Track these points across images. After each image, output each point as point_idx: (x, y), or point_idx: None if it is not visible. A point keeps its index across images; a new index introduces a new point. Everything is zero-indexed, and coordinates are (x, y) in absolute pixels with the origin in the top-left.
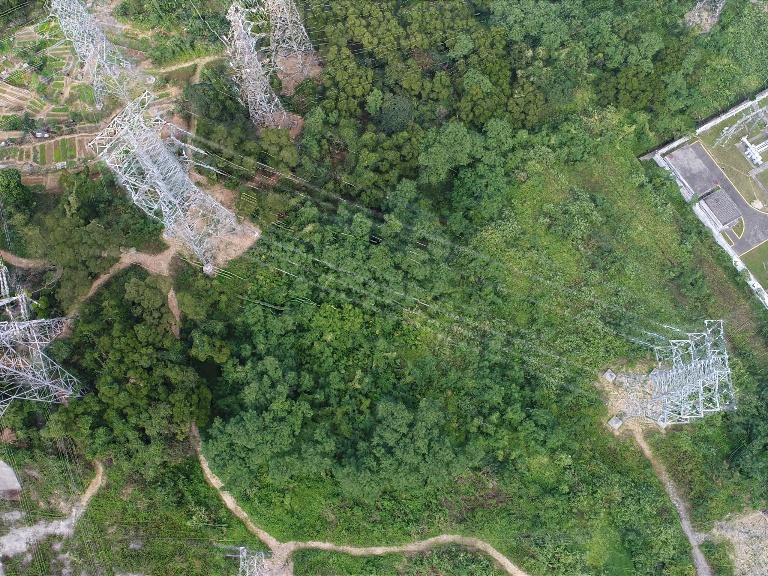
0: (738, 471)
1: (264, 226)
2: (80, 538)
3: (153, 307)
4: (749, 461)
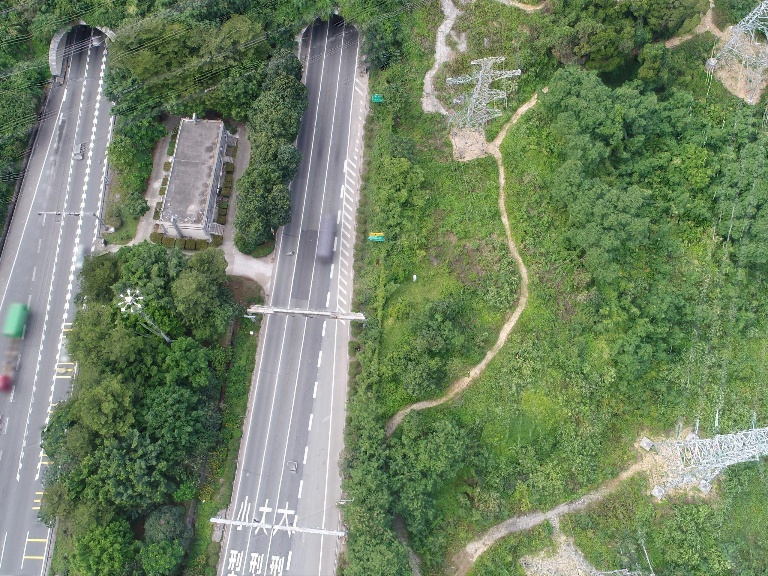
0: (627, 568)
1: (761, 104)
2: (488, 4)
3: (682, 0)
4: (642, 574)
